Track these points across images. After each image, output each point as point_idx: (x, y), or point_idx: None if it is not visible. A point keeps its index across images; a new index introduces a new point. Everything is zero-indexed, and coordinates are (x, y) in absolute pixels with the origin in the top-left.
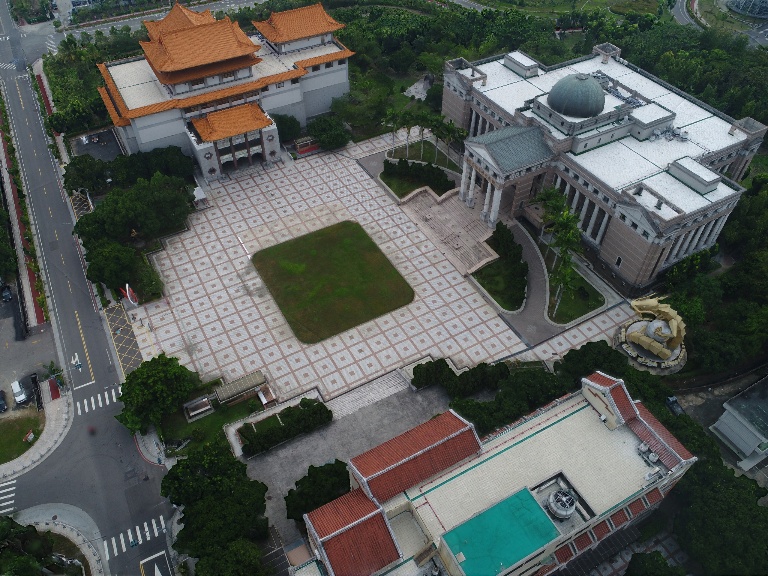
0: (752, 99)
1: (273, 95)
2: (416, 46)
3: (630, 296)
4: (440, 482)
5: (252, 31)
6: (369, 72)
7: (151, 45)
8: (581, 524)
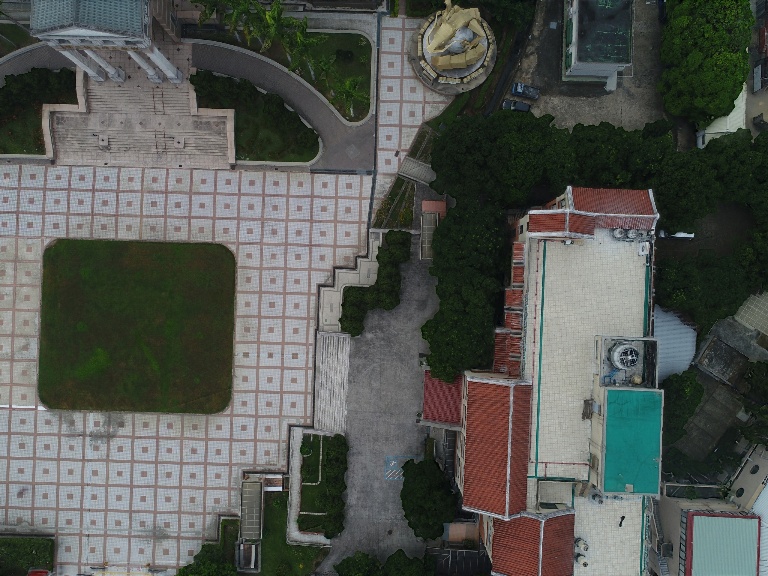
0: None
1: None
2: None
3: (378, 4)
4: (535, 440)
5: None
6: None
7: None
8: (642, 346)
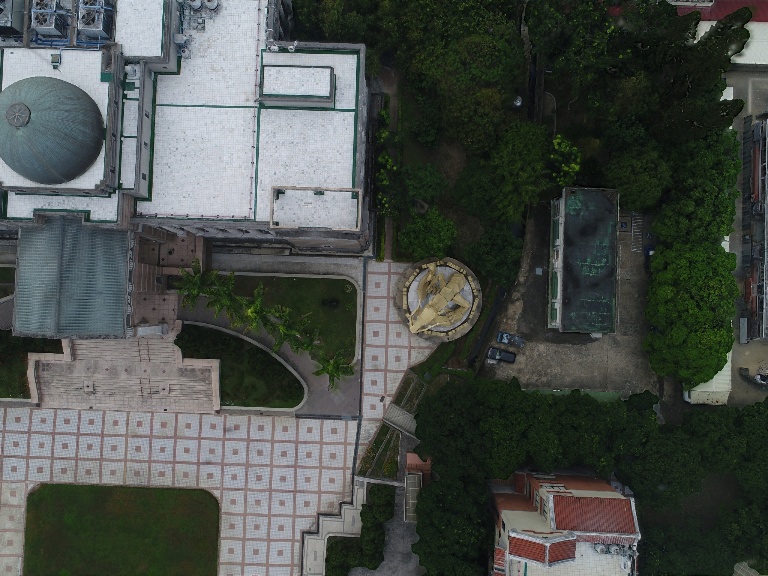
0: None
1: None
2: None
3: None
4: None
5: None
6: None
7: None
8: None
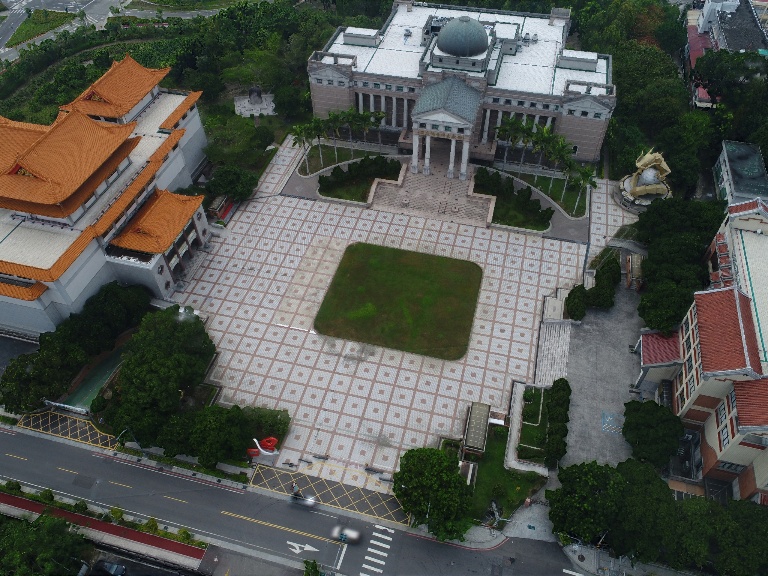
0: (500, 1)
1: (163, 172)
2: (200, 69)
3: None
4: (759, 337)
5: None
6: (200, 110)
7: None
8: None
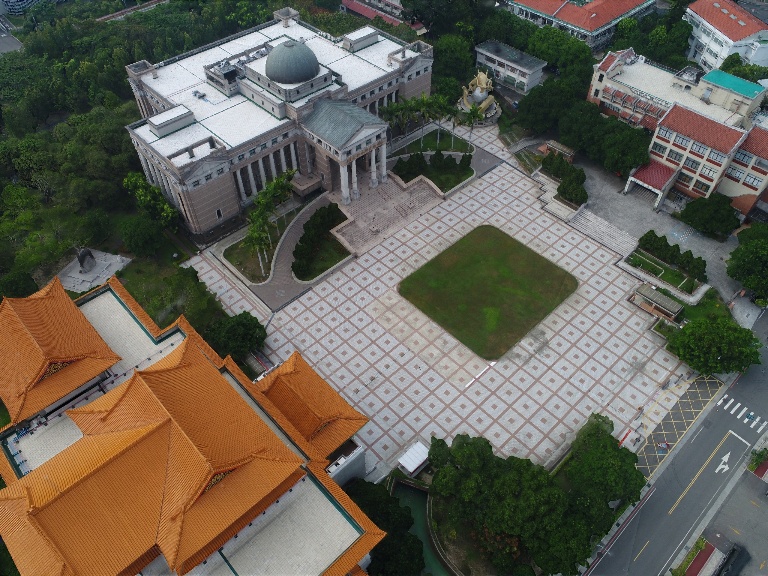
0: None
1: None
2: None
3: None
4: None
5: (1, 450)
6: None
7: (188, 532)
8: None
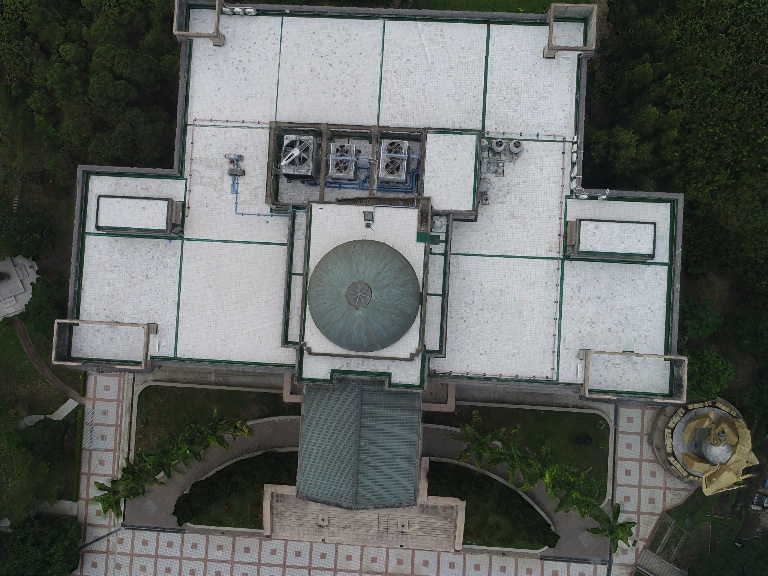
0: None
1: None
2: None
3: None
4: None
5: None
6: None
7: None
8: None
